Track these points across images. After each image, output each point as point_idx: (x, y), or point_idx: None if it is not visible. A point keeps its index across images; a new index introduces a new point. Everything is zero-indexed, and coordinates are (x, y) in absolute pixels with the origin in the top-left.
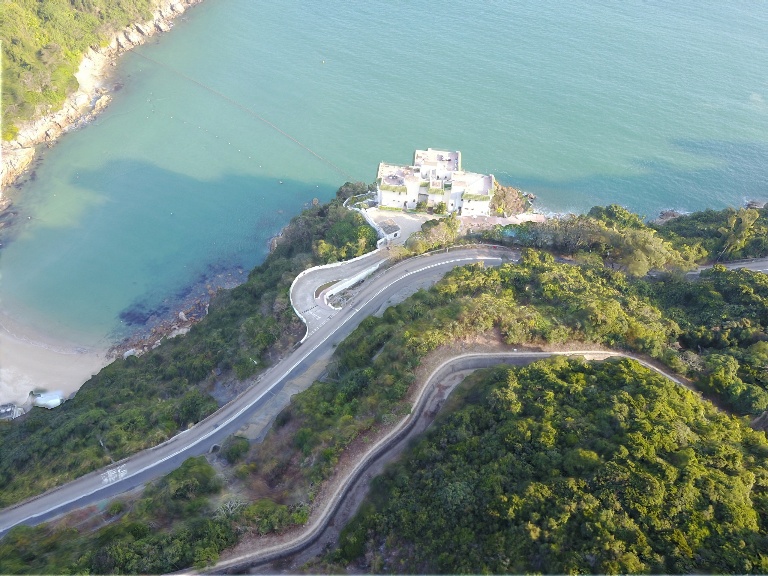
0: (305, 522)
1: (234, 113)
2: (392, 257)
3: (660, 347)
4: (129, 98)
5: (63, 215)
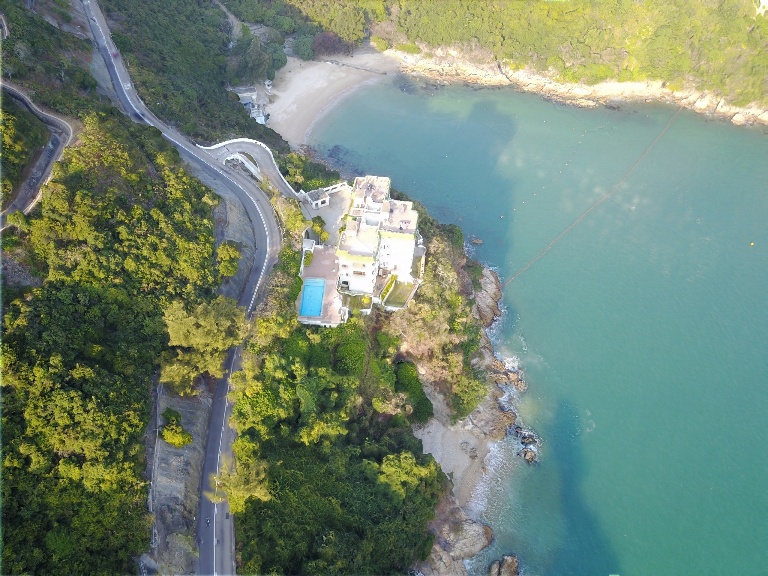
0: (0, 77)
1: (605, 180)
2: None
3: None
4: (603, 118)
5: (438, 108)
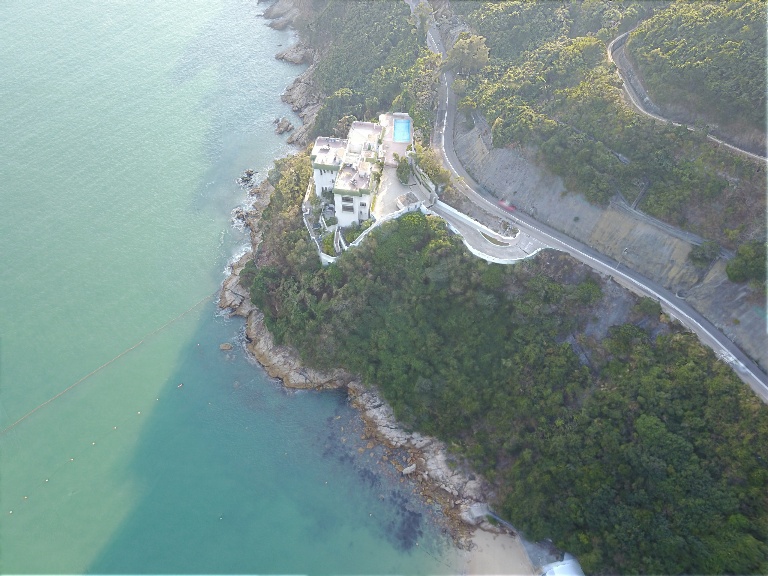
0: None
1: None
2: (454, 195)
3: None
4: None
5: None
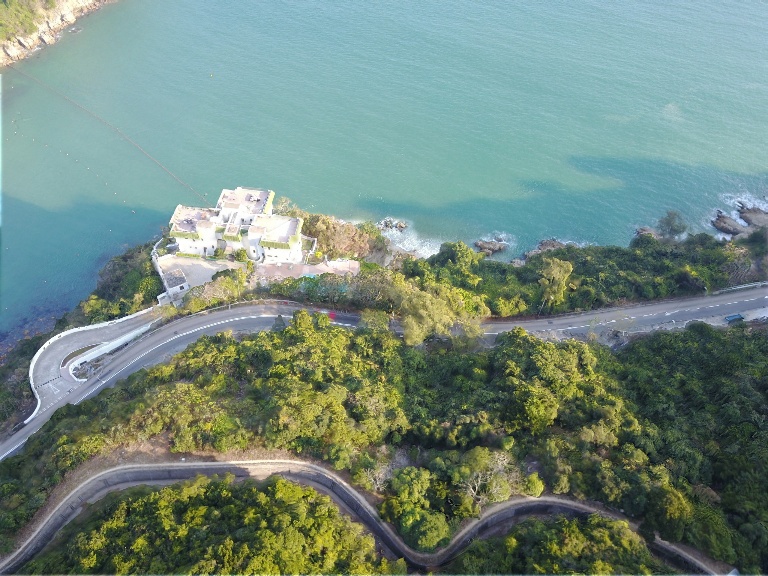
0: None
1: (102, 134)
2: (162, 317)
3: (348, 458)
4: None
5: None
